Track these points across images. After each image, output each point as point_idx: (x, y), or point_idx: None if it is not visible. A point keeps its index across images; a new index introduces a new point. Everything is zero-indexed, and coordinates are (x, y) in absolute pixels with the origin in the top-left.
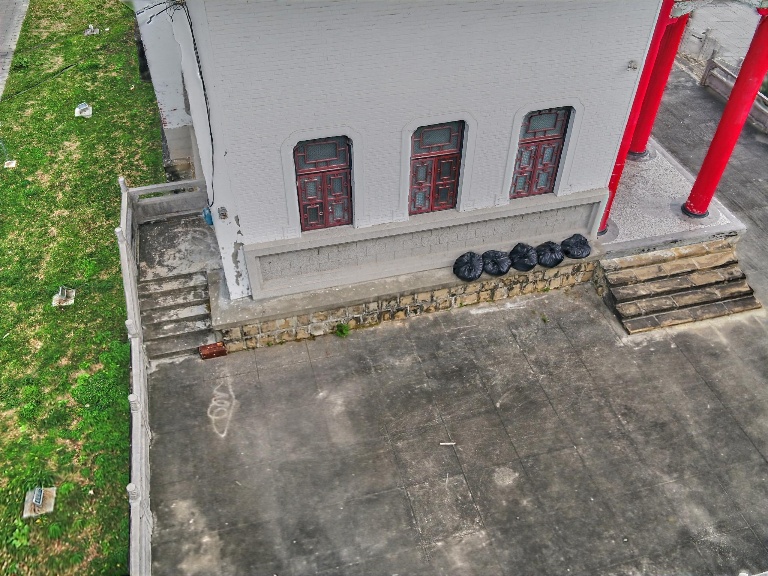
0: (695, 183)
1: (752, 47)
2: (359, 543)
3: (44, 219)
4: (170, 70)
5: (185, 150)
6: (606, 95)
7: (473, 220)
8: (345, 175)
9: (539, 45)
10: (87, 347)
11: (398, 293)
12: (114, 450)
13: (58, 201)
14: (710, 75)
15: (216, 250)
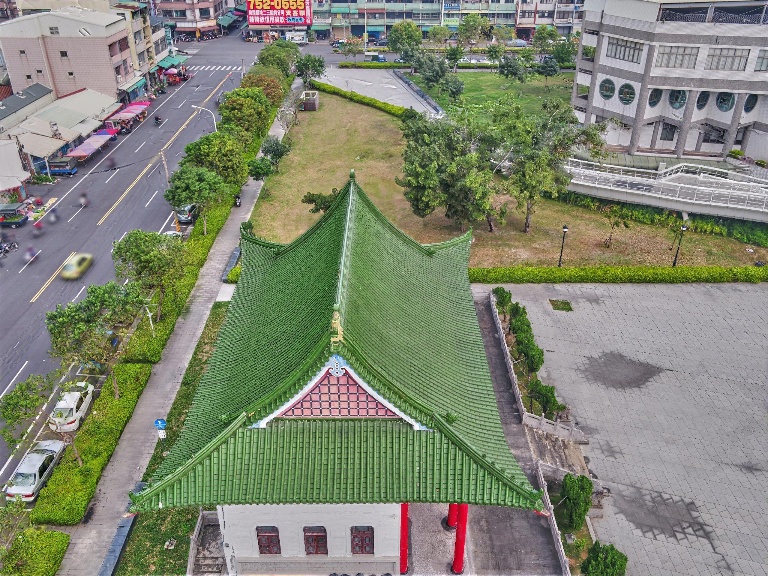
0: None
1: None
2: None
3: None
4: None
5: None
6: (387, 524)
7: (334, 562)
8: (277, 537)
9: (351, 506)
10: (173, 575)
11: None
12: None
13: None
14: (537, 471)
15: None
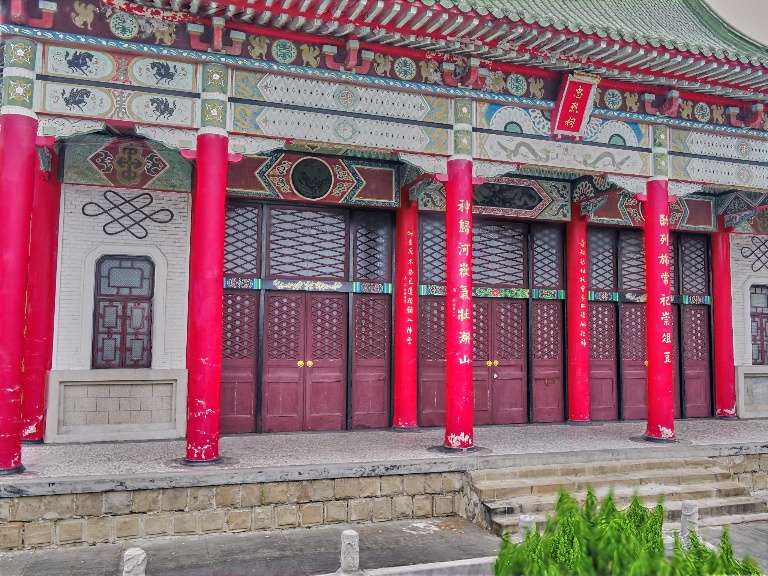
0: None
1: None
2: None
3: None
4: None
5: None
6: None
7: None
8: None
9: None
10: None
11: None
12: None
13: None
14: None
15: None
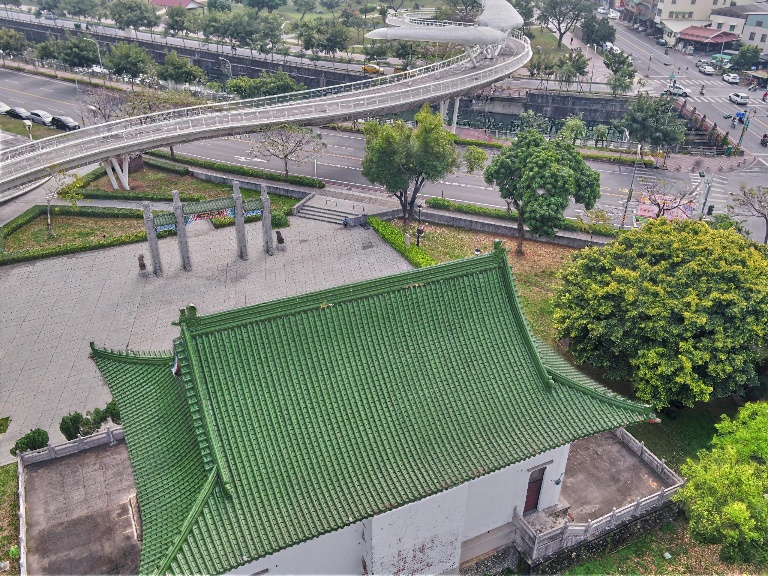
0: None
1: None
2: (609, 468)
3: None
4: None
5: None
6: None
7: None
8: None
9: None
10: None
11: None
12: (602, 569)
13: None
14: None
15: (535, 516)
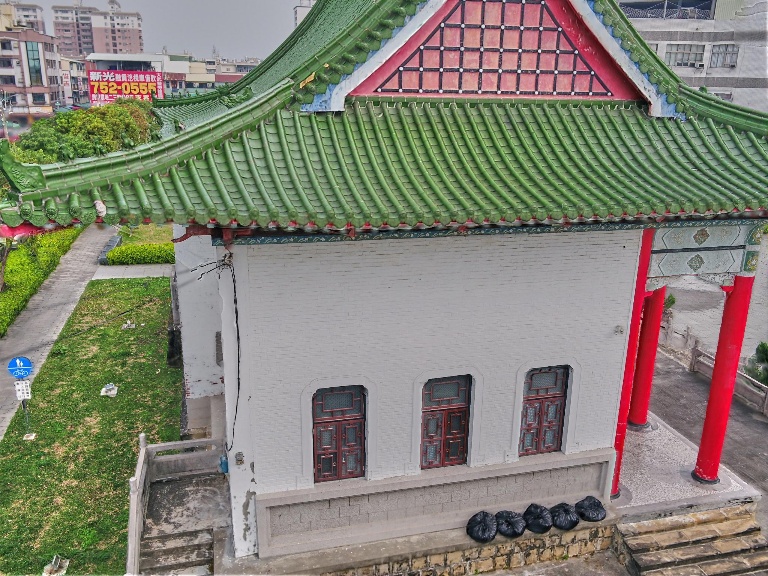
0: (700, 448)
1: (724, 319)
2: None
3: (52, 488)
4: (200, 345)
5: (203, 420)
6: (599, 356)
7: (484, 476)
8: (359, 425)
9: (534, 309)
10: None
11: (410, 554)
12: None
13: (69, 471)
14: (697, 362)
15: (225, 508)
